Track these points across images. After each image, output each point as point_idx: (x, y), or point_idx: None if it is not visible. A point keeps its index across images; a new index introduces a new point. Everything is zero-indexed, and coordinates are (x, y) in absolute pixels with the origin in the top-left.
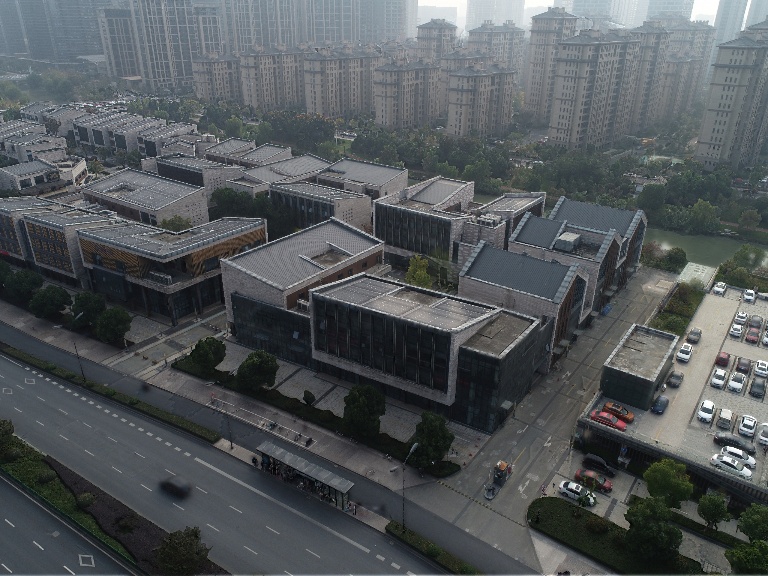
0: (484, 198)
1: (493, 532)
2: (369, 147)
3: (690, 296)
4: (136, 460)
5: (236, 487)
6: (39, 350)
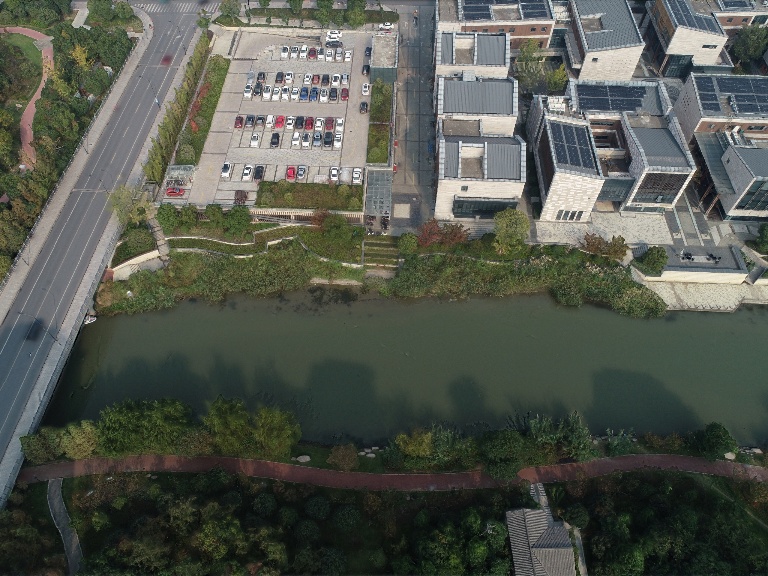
0: None
1: (406, 8)
2: None
3: None
4: None
5: None
6: None
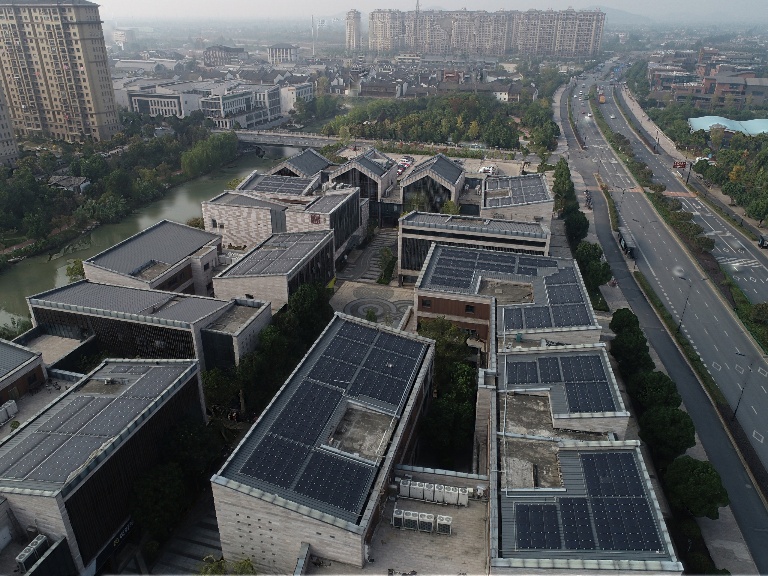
0: (20, 272)
1: None
2: None
3: None
4: None
5: None
6: (691, 390)
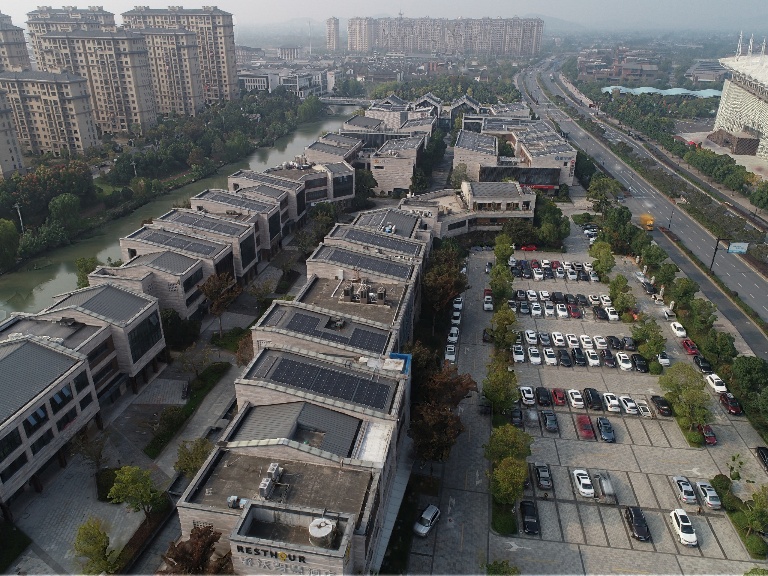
0: (265, 151)
1: None
2: (146, 169)
3: None
4: None
5: (576, 140)
6: None
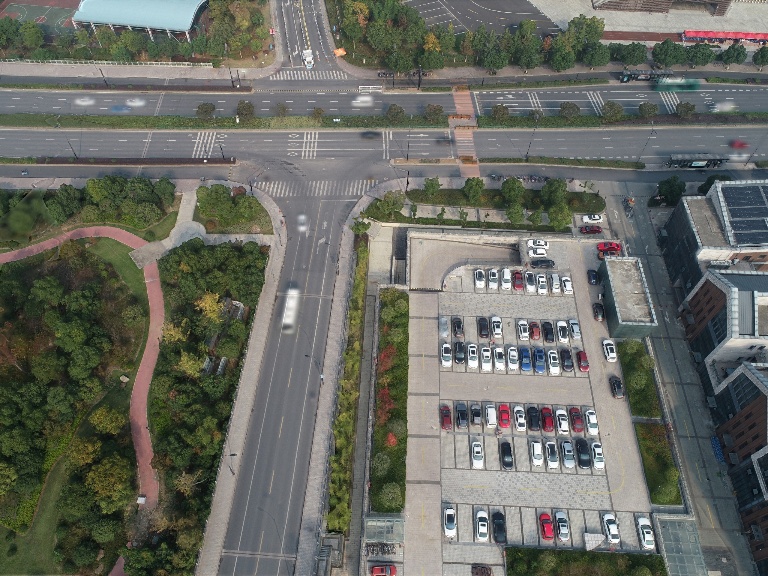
0: None
1: (608, 186)
2: None
3: (660, 475)
4: (767, 142)
5: (715, 153)
6: None
